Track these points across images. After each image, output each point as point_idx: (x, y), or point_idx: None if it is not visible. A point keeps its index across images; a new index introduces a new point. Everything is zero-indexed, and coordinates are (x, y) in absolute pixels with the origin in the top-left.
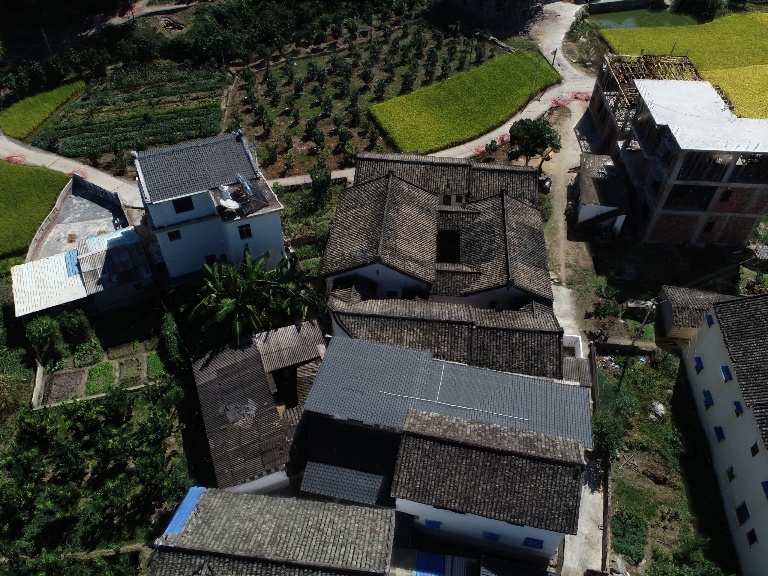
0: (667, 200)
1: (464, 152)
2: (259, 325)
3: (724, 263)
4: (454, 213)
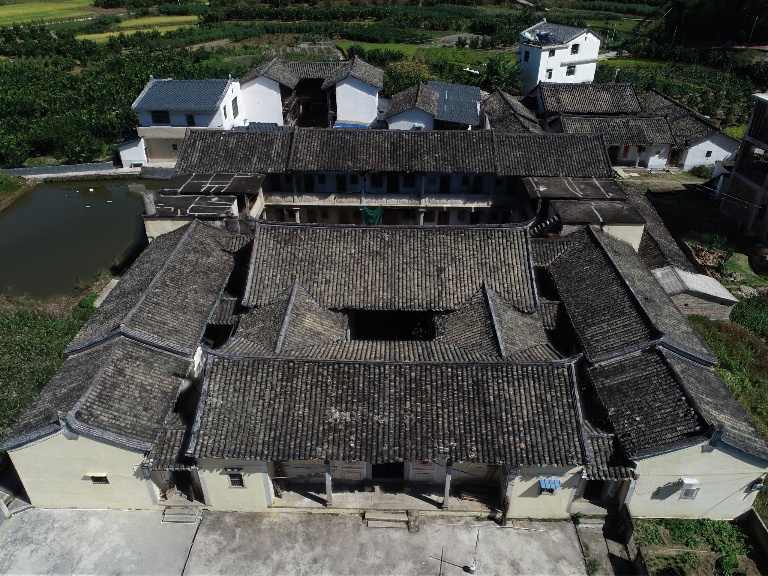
0: (753, 170)
1: (762, 152)
2: (479, 83)
3: (737, 245)
4: None
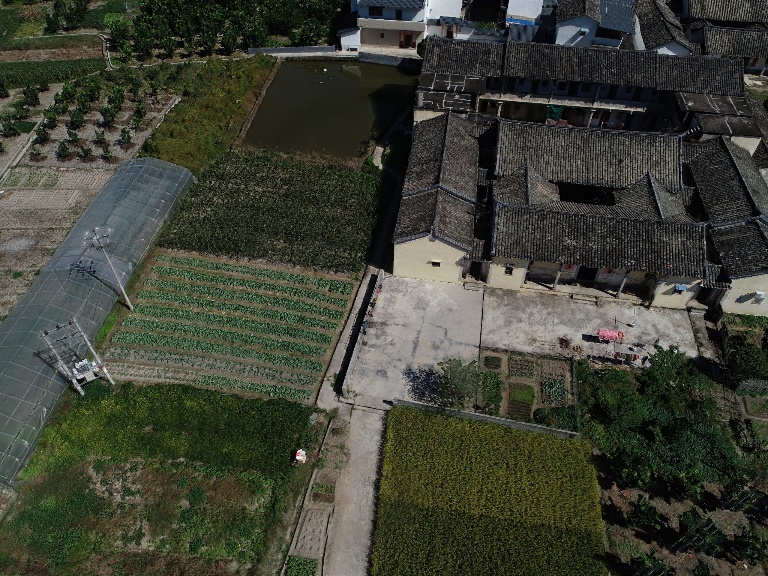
0: None
1: None
2: None
3: None
4: (765, 27)
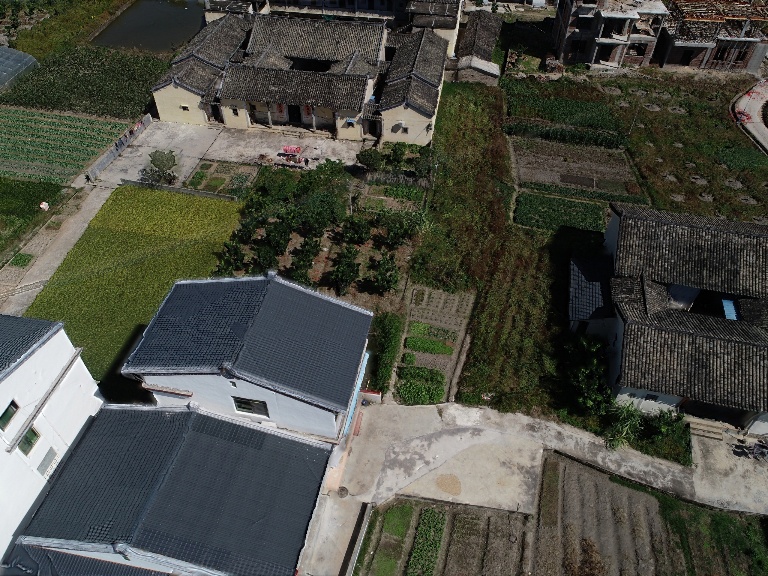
0: None
1: None
2: None
3: (540, 54)
4: None
